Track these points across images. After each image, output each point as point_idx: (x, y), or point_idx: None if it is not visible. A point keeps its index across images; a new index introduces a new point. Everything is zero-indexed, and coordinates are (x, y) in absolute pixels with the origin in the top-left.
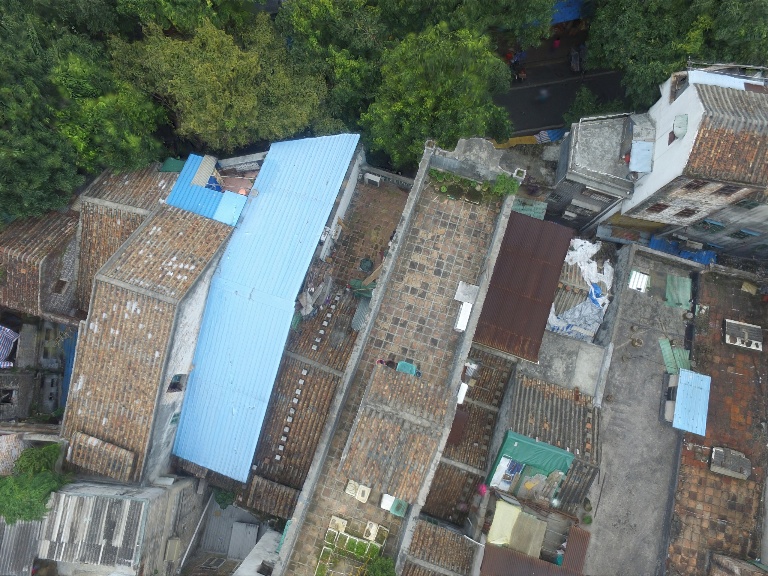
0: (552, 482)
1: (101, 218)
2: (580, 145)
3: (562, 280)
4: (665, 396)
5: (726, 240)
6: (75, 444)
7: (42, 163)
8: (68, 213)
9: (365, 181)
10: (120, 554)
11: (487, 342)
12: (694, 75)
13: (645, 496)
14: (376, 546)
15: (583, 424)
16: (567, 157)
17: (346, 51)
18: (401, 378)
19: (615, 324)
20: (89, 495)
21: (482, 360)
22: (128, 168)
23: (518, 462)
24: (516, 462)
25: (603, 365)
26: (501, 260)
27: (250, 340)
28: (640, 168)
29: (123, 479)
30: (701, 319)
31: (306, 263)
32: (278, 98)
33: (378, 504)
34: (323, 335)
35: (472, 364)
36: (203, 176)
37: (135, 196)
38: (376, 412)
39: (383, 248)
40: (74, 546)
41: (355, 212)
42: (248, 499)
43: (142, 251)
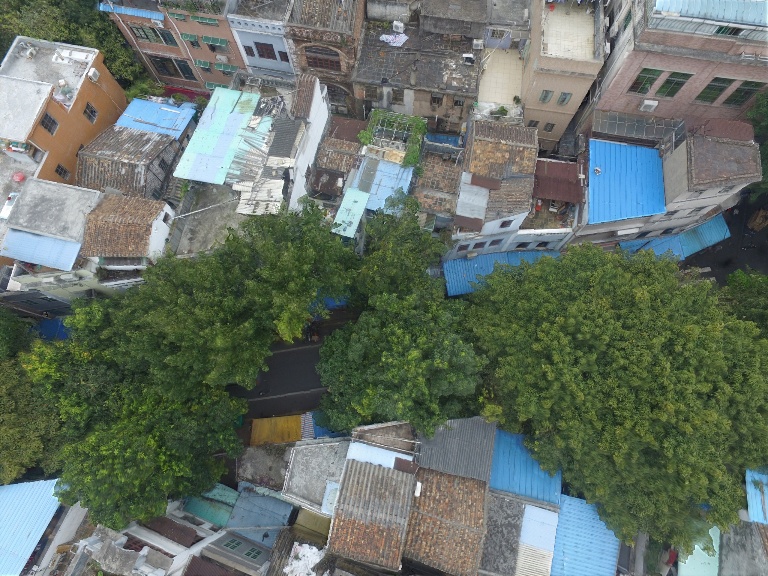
0: None
1: None
2: (300, 464)
3: None
4: None
5: None
6: None
7: None
8: None
9: None
10: None
11: None
12: (353, 449)
13: None
14: None
15: None
16: None
17: (72, 400)
18: None
19: None
20: None
21: None
22: None
23: None
24: None
25: None
26: None
27: None
28: None
29: None
30: None
31: None
32: (3, 446)
33: None
34: None
35: None
36: None
37: None
38: None
39: None
40: None
41: (87, 528)
42: None
43: None
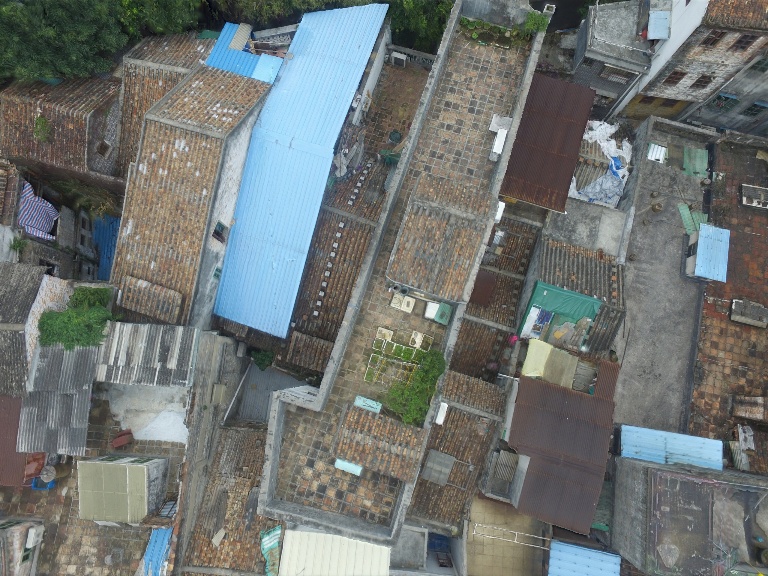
0: (580, 329)
1: (143, 80)
2: (597, 25)
3: (583, 154)
4: (685, 255)
5: (739, 120)
6: (125, 287)
7: (90, 14)
8: (110, 80)
9: (391, 62)
10: (175, 376)
11: (516, 195)
12: None
13: (669, 347)
14: (422, 351)
15: (608, 277)
16: (585, 37)
17: None
18: (444, 183)
19: (636, 189)
20: (143, 324)
21: (508, 228)
22: (166, 37)
23: (547, 311)
24: (545, 311)
25: (625, 227)
26: (527, 119)
27: (290, 190)
28: (657, 35)
29: (172, 320)
30: (718, 183)
31: (342, 116)
32: None
33: (422, 316)
34: (357, 194)
35: (499, 231)
36: (240, 41)
37: (175, 58)
38: (423, 209)
39: (410, 123)
40: (130, 369)
41: (382, 91)
42: (288, 355)
43: (187, 99)
